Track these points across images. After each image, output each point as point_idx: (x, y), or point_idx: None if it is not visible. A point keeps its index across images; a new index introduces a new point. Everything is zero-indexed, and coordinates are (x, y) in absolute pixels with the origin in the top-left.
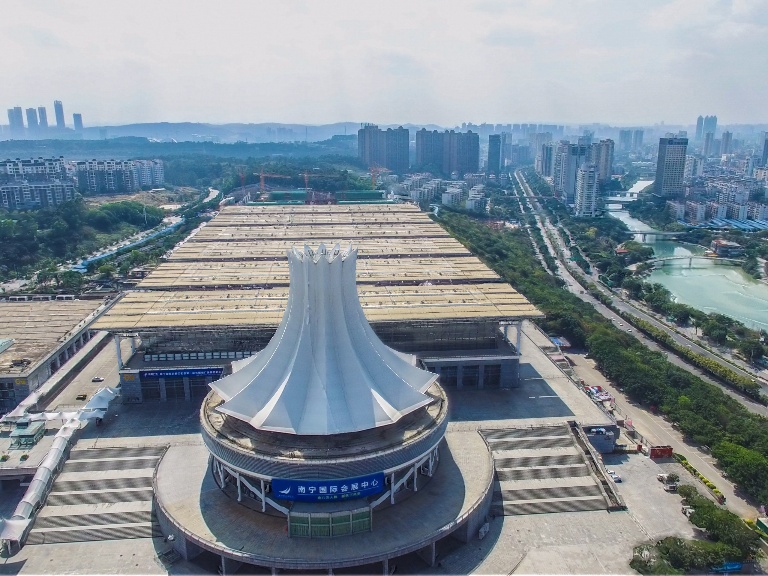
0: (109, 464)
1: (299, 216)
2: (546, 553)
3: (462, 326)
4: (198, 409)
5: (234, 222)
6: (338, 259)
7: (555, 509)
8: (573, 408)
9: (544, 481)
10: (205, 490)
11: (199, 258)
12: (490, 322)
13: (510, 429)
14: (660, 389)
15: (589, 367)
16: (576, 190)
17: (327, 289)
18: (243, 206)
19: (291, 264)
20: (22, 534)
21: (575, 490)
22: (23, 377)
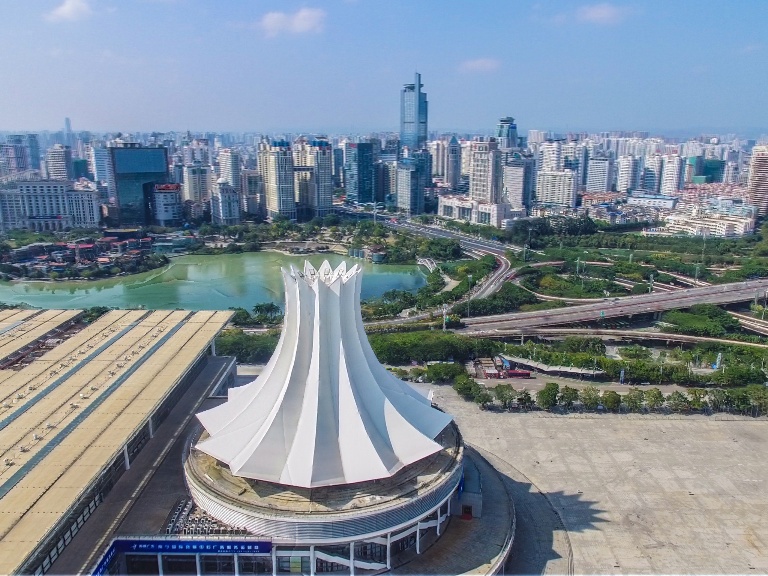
0: None
1: None
2: None
3: None
4: None
5: None
6: None
7: None
8: None
9: None
10: None
11: None
12: None
13: None
14: (269, 345)
15: None
16: None
17: None
18: None
19: (323, 294)
20: None
21: None
22: None
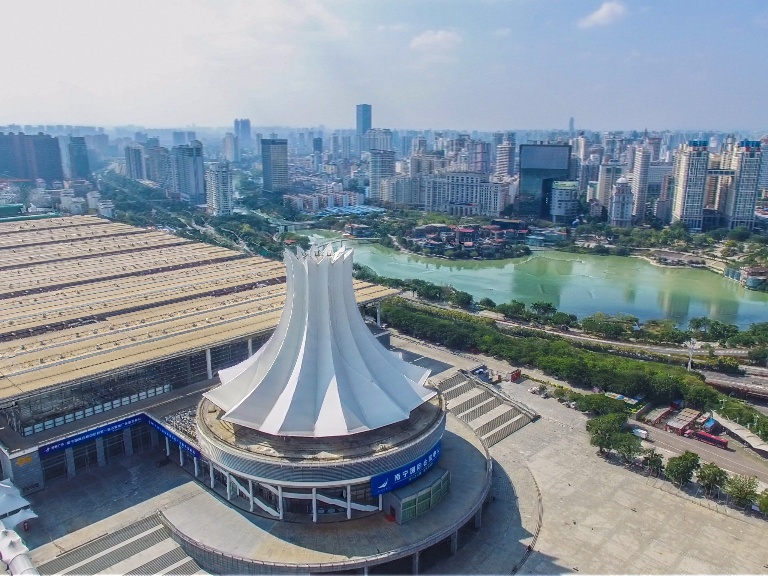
0: (106, 559)
1: None
2: (537, 461)
3: None
4: (130, 469)
5: None
6: (351, 257)
7: (507, 433)
8: (446, 362)
9: (483, 417)
10: (268, 528)
11: None
12: (360, 306)
13: None
14: (471, 335)
15: (396, 334)
16: (208, 190)
17: None
18: None
19: (297, 269)
20: None
21: (506, 416)
22: None
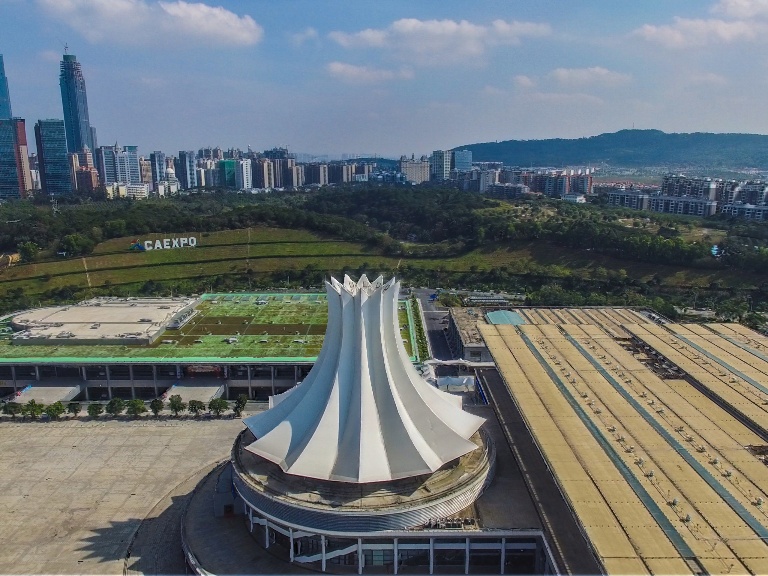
0: None
1: None
2: None
3: None
4: None
5: None
6: None
7: None
8: None
9: None
10: None
11: None
12: None
13: None
14: None
15: None
16: None
17: None
18: None
19: None
20: None
21: None
22: None
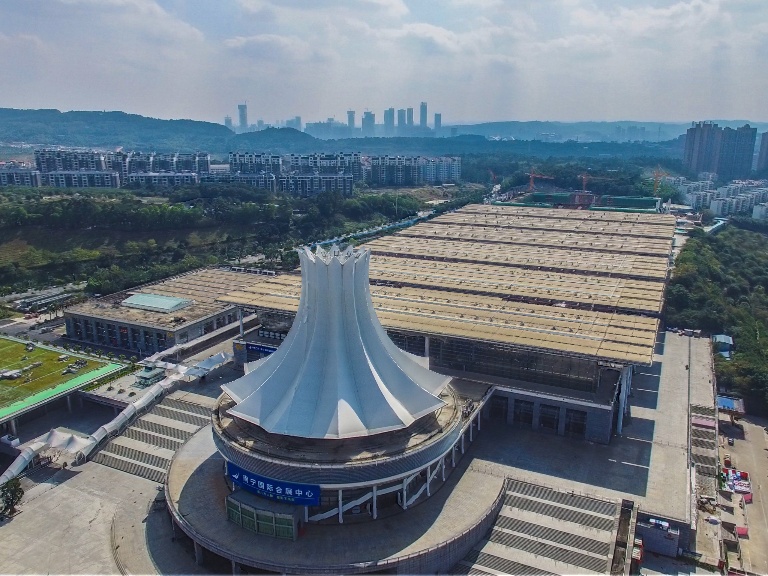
0: (181, 415)
1: (526, 219)
2: None
3: (552, 358)
4: None
5: (455, 220)
6: (333, 262)
7: None
8: (652, 487)
9: (540, 559)
10: (213, 457)
11: (377, 251)
12: (586, 359)
13: (544, 488)
14: None
15: (761, 446)
16: None
17: (324, 291)
18: (485, 205)
19: None
20: (90, 451)
21: None
22: (172, 331)
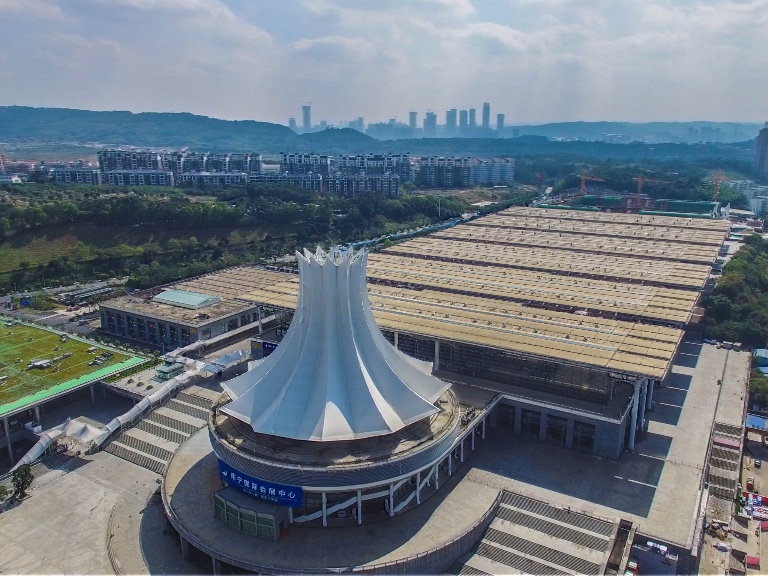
0: (192, 410)
1: (568, 223)
2: None
3: (562, 367)
4: None
5: (495, 223)
6: (327, 263)
7: None
8: (656, 507)
9: (525, 575)
10: (214, 453)
11: (407, 252)
12: (597, 370)
13: (540, 502)
14: None
15: None
16: None
17: (319, 292)
18: (530, 208)
19: None
20: (103, 441)
21: None
22: (195, 327)
